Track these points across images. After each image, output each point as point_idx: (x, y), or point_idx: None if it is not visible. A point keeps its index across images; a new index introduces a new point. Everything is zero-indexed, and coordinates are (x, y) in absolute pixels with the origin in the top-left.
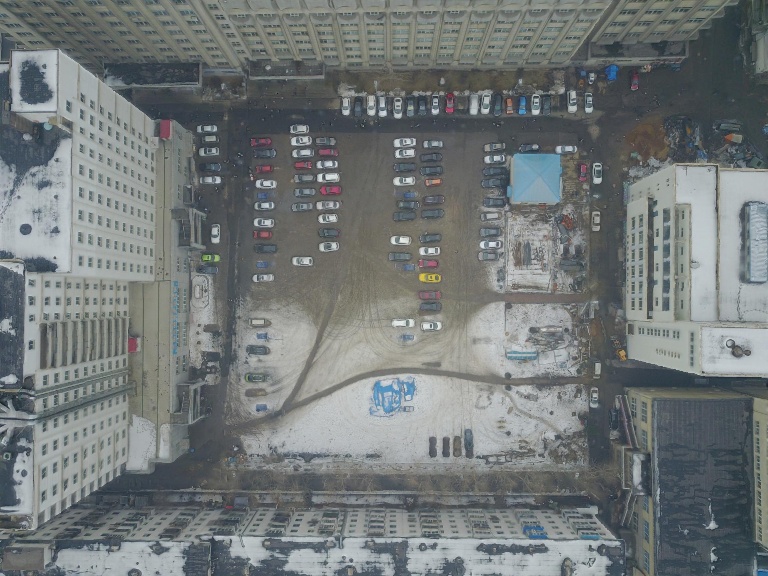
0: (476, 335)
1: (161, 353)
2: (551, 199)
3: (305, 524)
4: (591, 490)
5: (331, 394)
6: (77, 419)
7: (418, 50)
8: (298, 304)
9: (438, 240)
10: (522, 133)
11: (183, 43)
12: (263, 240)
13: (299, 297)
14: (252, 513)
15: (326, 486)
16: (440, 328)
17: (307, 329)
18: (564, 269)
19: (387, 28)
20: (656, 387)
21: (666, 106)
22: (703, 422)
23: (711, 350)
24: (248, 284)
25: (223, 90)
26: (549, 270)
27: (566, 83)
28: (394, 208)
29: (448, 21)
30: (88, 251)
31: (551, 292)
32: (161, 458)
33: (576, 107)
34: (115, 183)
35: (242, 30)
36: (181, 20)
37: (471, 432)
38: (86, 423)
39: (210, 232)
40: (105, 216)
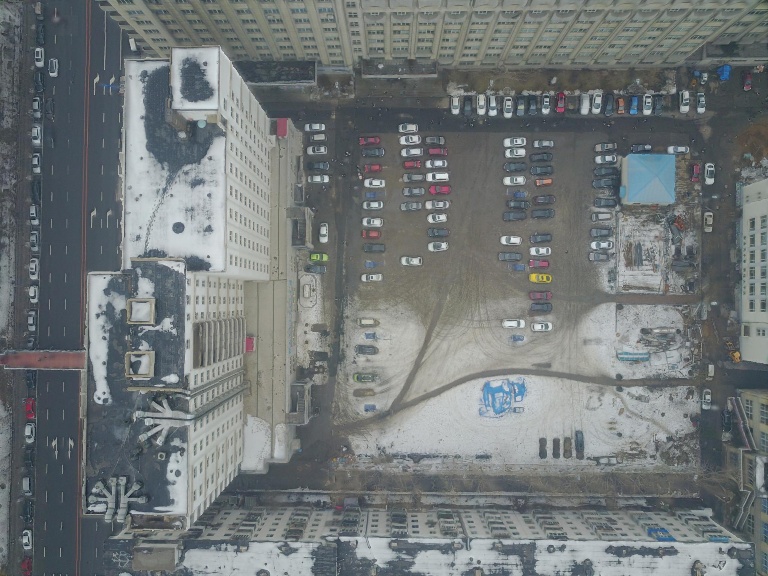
0: (586, 336)
1: (276, 353)
2: (666, 200)
3: (423, 525)
4: (703, 492)
5: (440, 394)
6: (213, 419)
7: (536, 49)
8: (407, 304)
9: (549, 240)
10: (633, 133)
11: (306, 41)
12: (371, 239)
13: (408, 297)
14: (364, 514)
15: (435, 487)
16: (551, 329)
17: (416, 329)
18: (676, 270)
19: (516, 27)
20: None
21: None
22: None
23: None
24: (356, 284)
25: (331, 88)
26: (660, 271)
27: (677, 83)
28: (504, 208)
29: (581, 20)
30: (235, 250)
31: (663, 293)
32: (276, 458)
33: (688, 107)
34: (249, 182)
35: (369, 28)
36: (315, 18)
37: (582, 433)
38: (219, 423)
39: (318, 231)
40: (243, 215)
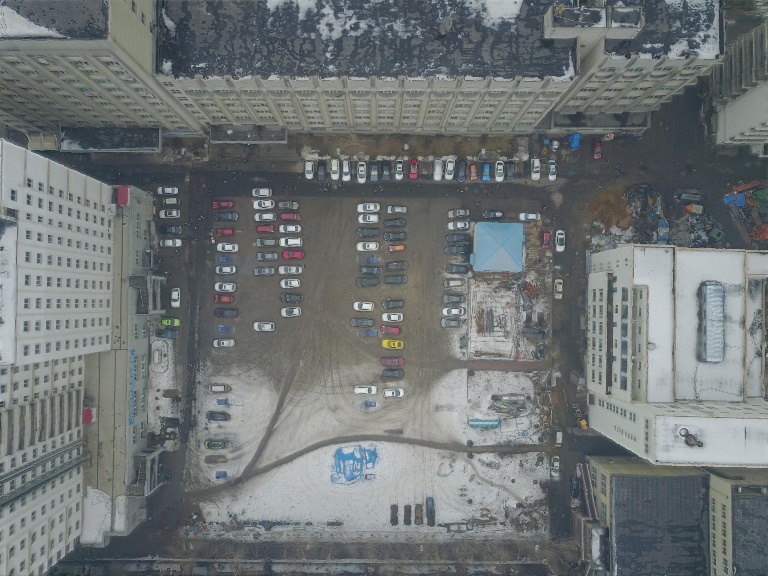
0: (438, 402)
1: (117, 423)
2: (513, 268)
3: None
4: (552, 558)
5: (292, 461)
6: (24, 505)
7: (381, 119)
8: (259, 370)
9: (401, 306)
10: (486, 199)
11: (141, 112)
12: (224, 304)
13: (260, 362)
14: None
15: (286, 554)
16: (402, 395)
17: (268, 395)
18: (526, 337)
19: (347, 103)
20: (617, 456)
21: (629, 174)
22: (660, 499)
23: (665, 438)
24: (209, 349)
25: (185, 151)
26: (512, 337)
27: (530, 150)
28: (357, 273)
29: (408, 99)
30: (35, 338)
31: (513, 359)
32: (116, 531)
33: (540, 174)
34: (67, 261)
35: (200, 102)
36: (136, 95)
37: (432, 500)
38: (34, 506)
39: (170, 296)
40: (55, 297)
